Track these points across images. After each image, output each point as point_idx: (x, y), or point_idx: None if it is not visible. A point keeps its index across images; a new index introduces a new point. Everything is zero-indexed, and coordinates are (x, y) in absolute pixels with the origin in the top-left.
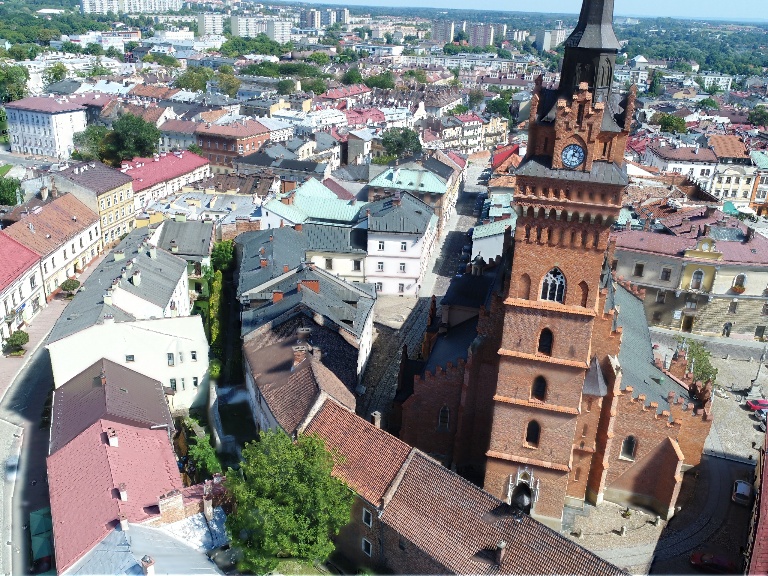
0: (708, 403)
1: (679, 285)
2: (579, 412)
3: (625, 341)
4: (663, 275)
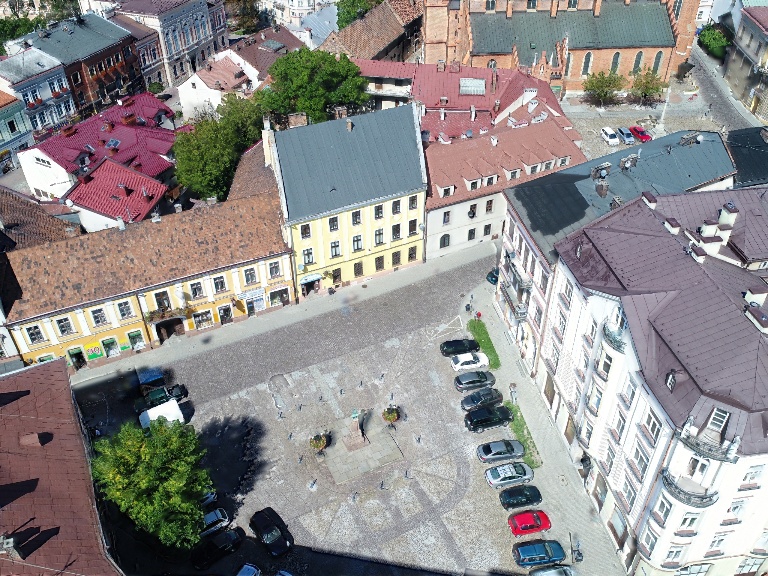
0: (532, 64)
1: (759, 61)
2: (426, 5)
3: (559, 27)
4: (758, 49)
